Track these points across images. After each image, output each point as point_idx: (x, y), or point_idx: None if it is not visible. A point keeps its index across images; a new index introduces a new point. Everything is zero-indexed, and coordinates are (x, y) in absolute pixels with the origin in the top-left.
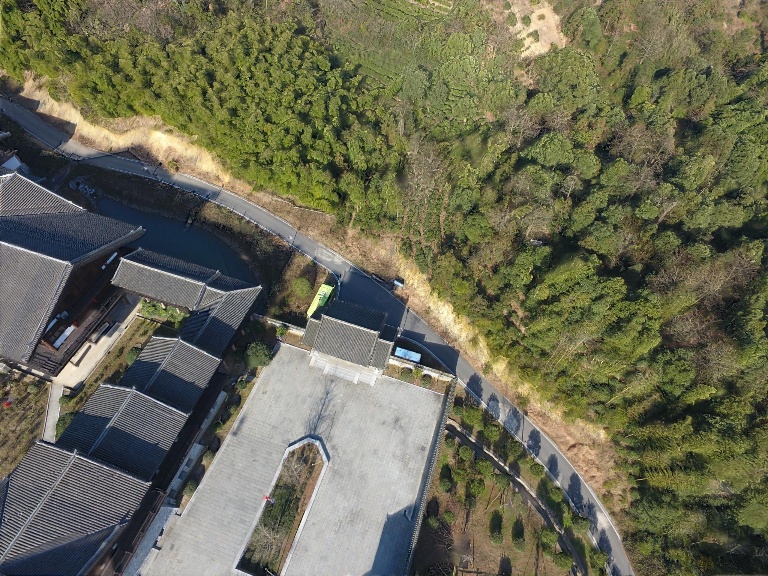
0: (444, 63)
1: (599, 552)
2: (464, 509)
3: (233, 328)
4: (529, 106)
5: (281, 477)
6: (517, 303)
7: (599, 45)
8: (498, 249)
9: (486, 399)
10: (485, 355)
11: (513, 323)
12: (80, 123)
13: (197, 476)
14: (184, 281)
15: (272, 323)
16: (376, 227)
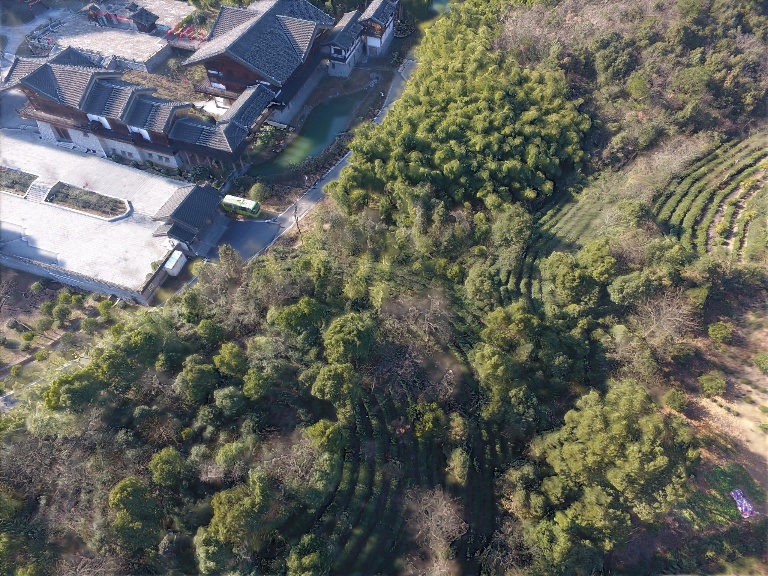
0: None
1: None
2: None
3: (197, 142)
4: None
5: None
6: None
7: None
8: None
9: None
10: None
11: None
12: None
13: (124, 162)
14: None
15: None
16: None
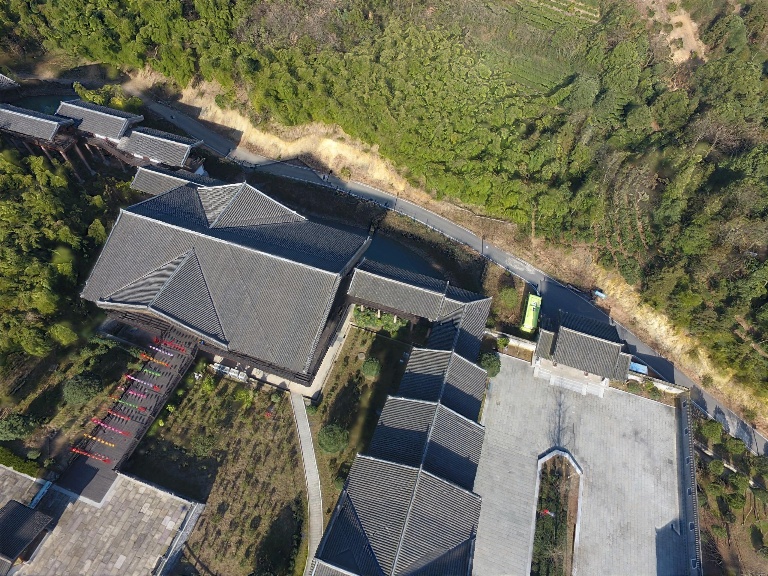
0: (610, 72)
1: None
2: (722, 523)
3: (479, 339)
4: (708, 116)
5: (542, 489)
6: (741, 315)
7: (743, 53)
8: (712, 261)
9: (712, 412)
10: (704, 367)
11: (738, 336)
12: (248, 130)
13: None
14: (422, 292)
15: (488, 333)
16: (566, 237)
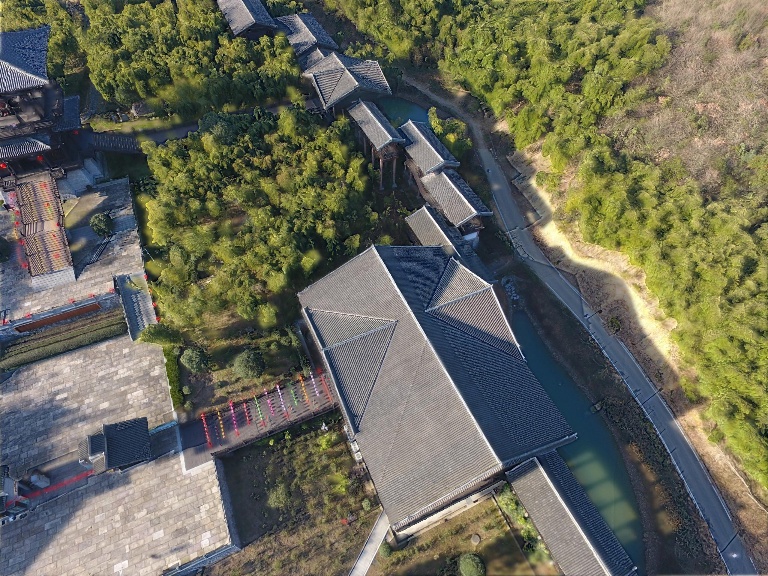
0: None
1: None
2: None
3: None
4: None
5: None
6: None
7: None
8: None
9: None
10: None
11: None
12: (546, 219)
13: None
14: (591, 553)
15: None
16: None
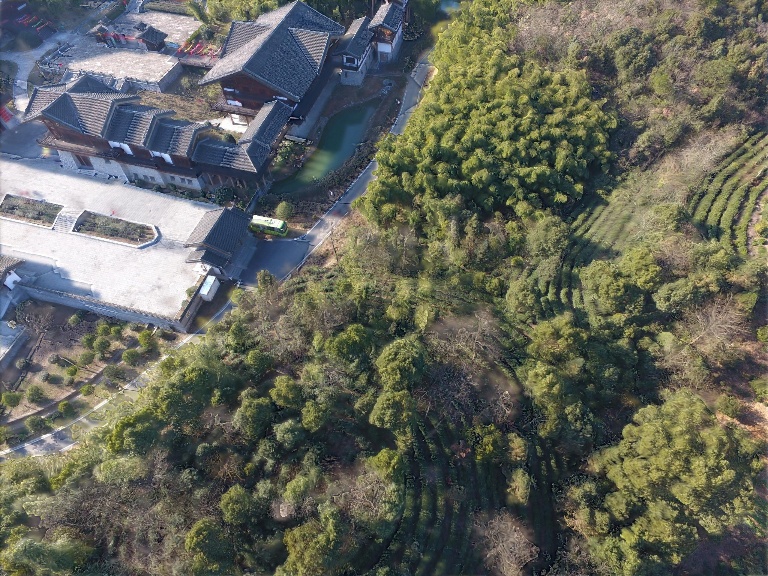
0: None
1: (4, 430)
2: None
3: (221, 163)
4: None
5: (134, 224)
6: None
7: None
8: None
9: None
10: None
11: None
12: None
13: (147, 186)
14: None
15: None
16: None
